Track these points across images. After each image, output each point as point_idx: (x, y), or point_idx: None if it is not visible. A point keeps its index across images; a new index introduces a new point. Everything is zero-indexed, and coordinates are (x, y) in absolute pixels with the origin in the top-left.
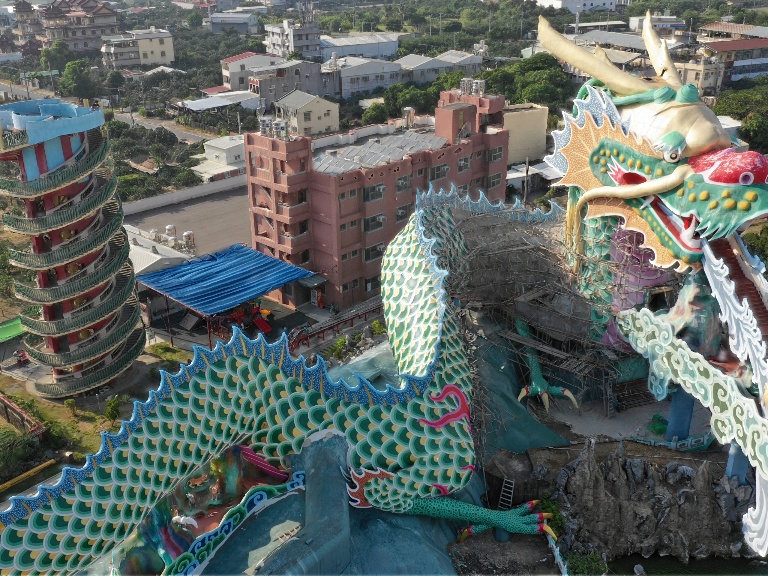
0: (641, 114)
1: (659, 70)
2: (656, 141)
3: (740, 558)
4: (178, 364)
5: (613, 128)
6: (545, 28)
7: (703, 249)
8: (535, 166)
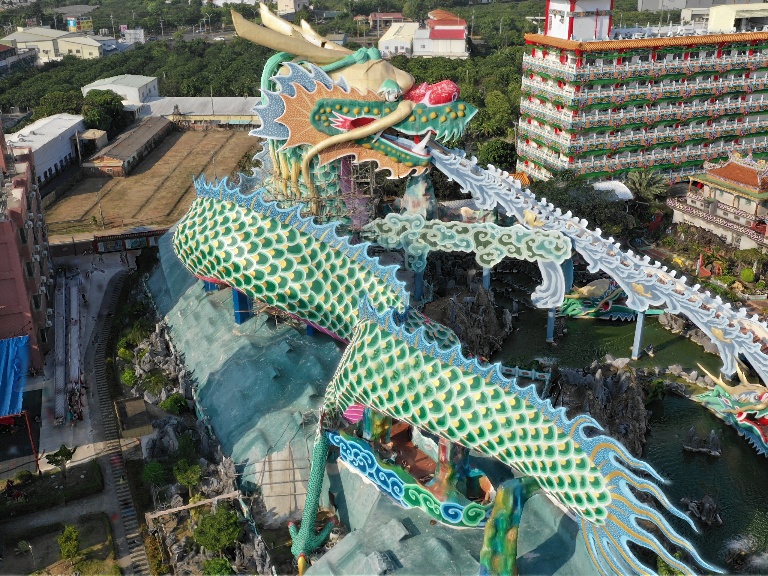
0: (352, 74)
1: (316, 44)
2: (379, 89)
3: (510, 334)
4: (8, 490)
5: (329, 90)
6: (241, 20)
7: (431, 153)
8: None
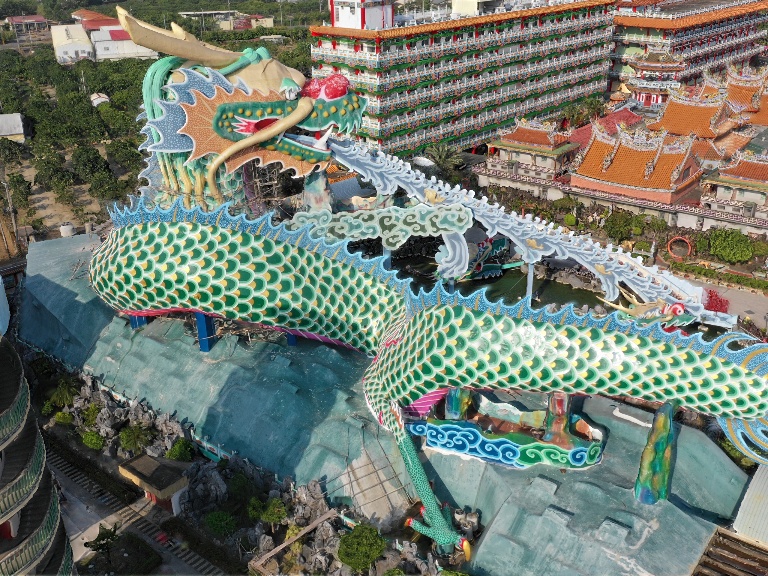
0: (250, 75)
1: None
2: (280, 88)
3: None
4: None
5: (230, 94)
6: (136, 26)
7: (331, 147)
8: None
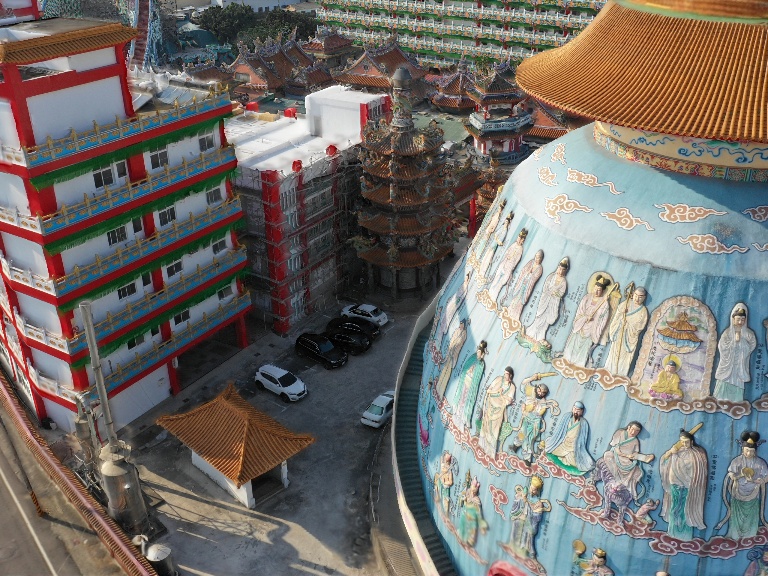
0: None
1: None
2: None
3: None
4: None
5: None
6: None
7: None
8: (197, 7)
